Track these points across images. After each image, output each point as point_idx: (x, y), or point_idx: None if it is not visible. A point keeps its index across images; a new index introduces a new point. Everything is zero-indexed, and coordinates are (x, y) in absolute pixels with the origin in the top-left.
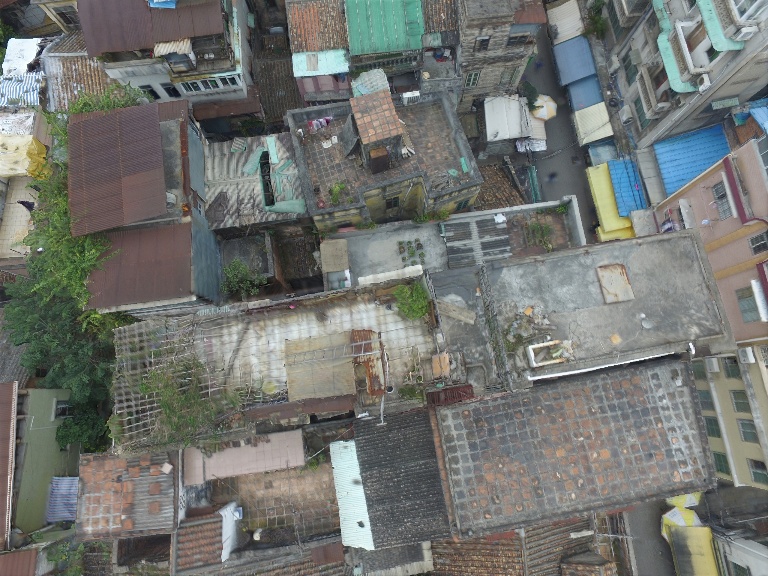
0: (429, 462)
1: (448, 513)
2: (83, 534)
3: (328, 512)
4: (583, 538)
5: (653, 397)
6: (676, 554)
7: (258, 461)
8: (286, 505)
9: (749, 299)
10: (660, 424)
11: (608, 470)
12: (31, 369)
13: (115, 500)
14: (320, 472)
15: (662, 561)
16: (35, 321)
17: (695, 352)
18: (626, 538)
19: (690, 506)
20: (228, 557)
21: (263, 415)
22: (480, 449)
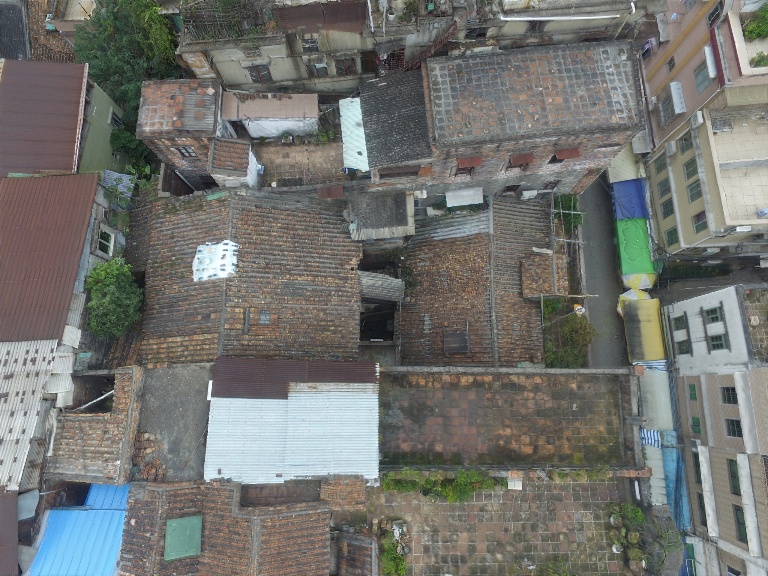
0: (418, 108)
1: (429, 132)
2: (142, 132)
3: (333, 177)
4: (543, 254)
5: (602, 66)
6: (627, 322)
7: (281, 110)
8: (299, 170)
9: (703, 71)
10: (605, 84)
11: (559, 111)
12: (95, 77)
13: (169, 111)
14: (329, 149)
15: (617, 343)
16: (100, 41)
17: (639, 31)
18: (579, 250)
19: (644, 288)
20: (251, 187)
21: (292, 27)
22: (459, 91)
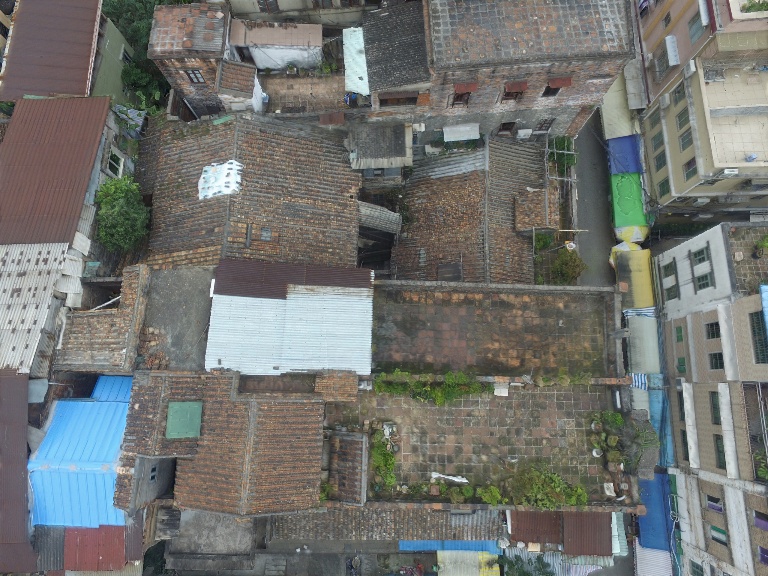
0: (418, 36)
1: (428, 56)
2: (153, 51)
3: (335, 107)
4: None
5: None
6: (619, 272)
7: (287, 39)
8: (302, 101)
9: (697, 22)
10: (598, 15)
11: (553, 38)
12: (108, 15)
13: (179, 33)
14: (331, 81)
15: None
16: None
17: None
18: (571, 190)
19: (636, 241)
20: (256, 111)
21: None
22: (458, 19)
